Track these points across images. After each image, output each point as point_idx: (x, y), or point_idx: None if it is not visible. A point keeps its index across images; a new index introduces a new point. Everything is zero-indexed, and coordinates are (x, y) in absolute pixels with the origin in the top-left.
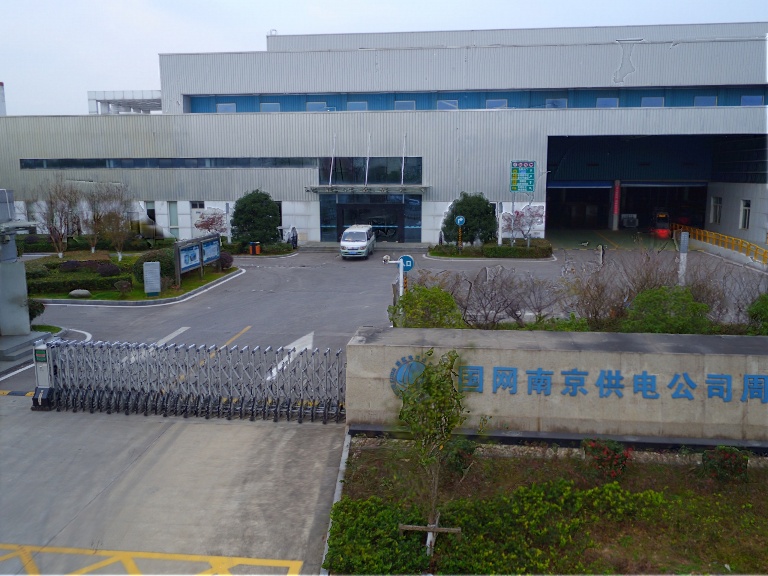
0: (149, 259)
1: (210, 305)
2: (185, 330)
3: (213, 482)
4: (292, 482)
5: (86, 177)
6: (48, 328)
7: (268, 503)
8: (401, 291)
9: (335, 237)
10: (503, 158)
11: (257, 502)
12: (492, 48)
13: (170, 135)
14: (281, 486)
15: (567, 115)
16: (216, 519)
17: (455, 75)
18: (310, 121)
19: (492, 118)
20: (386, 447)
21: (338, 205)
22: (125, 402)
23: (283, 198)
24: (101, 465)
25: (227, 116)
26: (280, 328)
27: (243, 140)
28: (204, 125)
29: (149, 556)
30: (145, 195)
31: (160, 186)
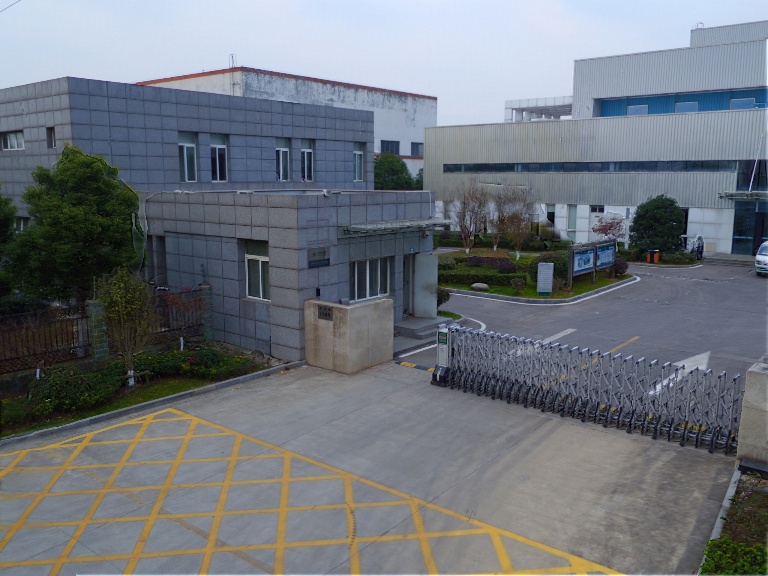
0: (544, 260)
1: (599, 310)
2: (571, 332)
3: (582, 484)
4: (665, 505)
5: (496, 180)
6: (451, 315)
7: (636, 520)
8: None
9: (750, 250)
10: None
11: (624, 516)
12: None
13: (577, 139)
14: (652, 506)
15: None
16: (581, 521)
17: None
18: (732, 120)
19: None
20: None
21: (758, 214)
22: (508, 391)
23: (691, 204)
24: (482, 444)
25: (637, 118)
26: (671, 343)
27: (652, 143)
28: (612, 128)
29: (514, 537)
30: (547, 198)
31: (562, 190)
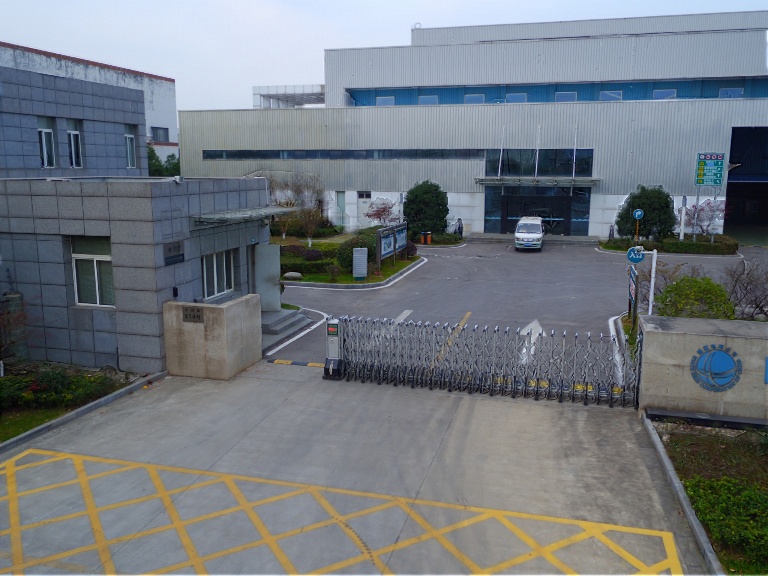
0: (353, 245)
1: (417, 291)
2: (410, 313)
3: (536, 454)
4: (614, 459)
5: (261, 167)
6: (287, 306)
7: (602, 477)
8: (653, 282)
9: (498, 229)
10: (681, 150)
11: (591, 475)
12: (664, 36)
13: (341, 127)
14: (605, 462)
15: (755, 105)
16: (561, 487)
17: (622, 65)
18: (479, 113)
19: (671, 109)
20: (692, 433)
21: (503, 197)
22: (408, 376)
23: (448, 189)
24: (419, 431)
25: (397, 109)
26: (501, 315)
27: (411, 132)
28: (374, 118)
29: (518, 515)
30: None
31: (330, 176)
